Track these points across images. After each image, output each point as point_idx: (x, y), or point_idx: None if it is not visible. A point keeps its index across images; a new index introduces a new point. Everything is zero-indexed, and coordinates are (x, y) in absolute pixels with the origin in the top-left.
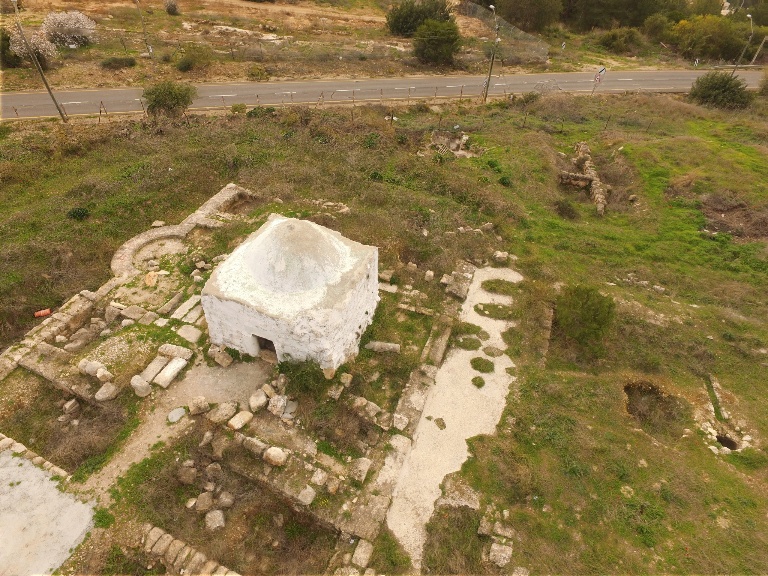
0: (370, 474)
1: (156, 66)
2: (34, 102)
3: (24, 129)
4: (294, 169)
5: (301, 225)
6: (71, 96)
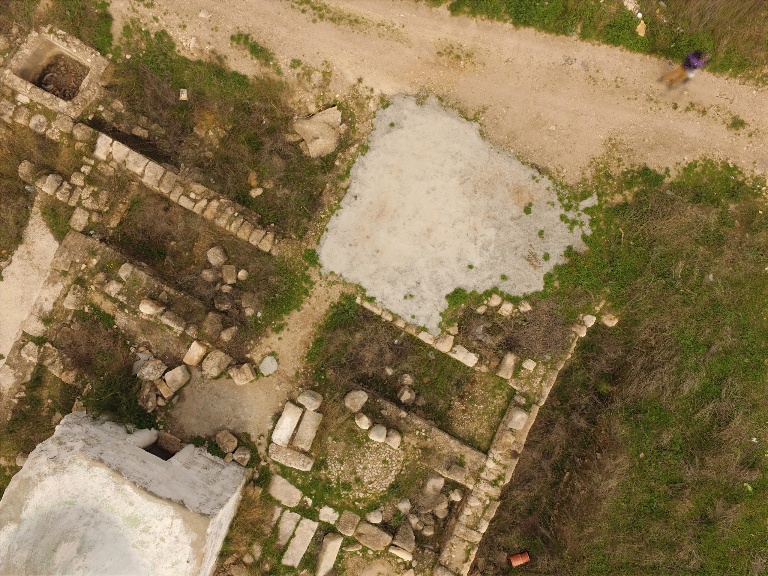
0: None
1: None
2: None
3: None
4: None
5: None
6: None
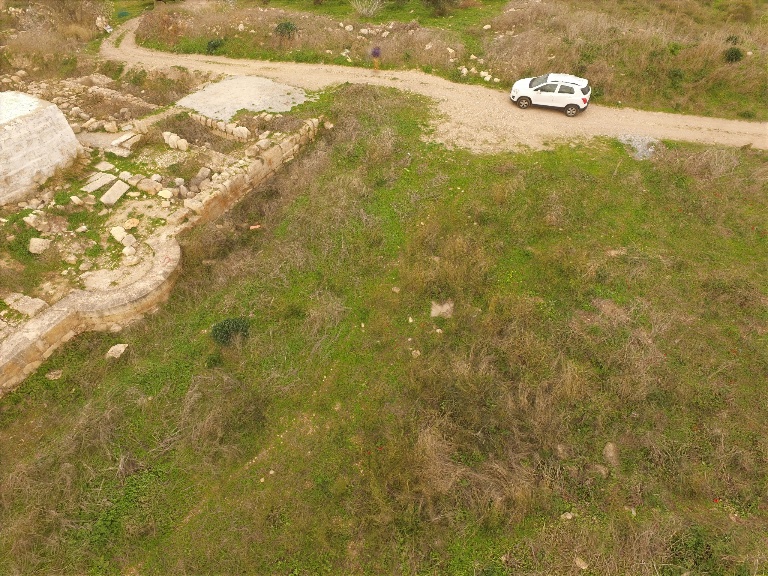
0: None
1: None
2: None
3: None
4: None
5: None
6: None
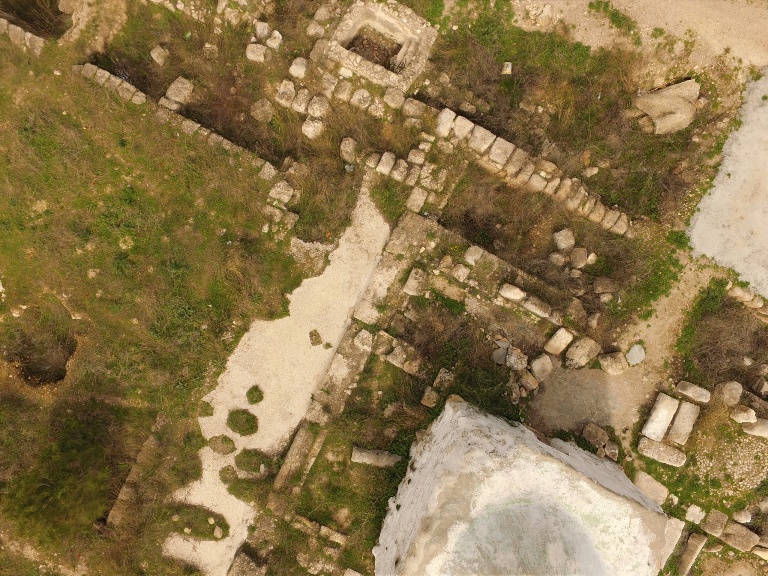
0: (405, 278)
1: None
2: None
3: None
4: None
5: None
6: None
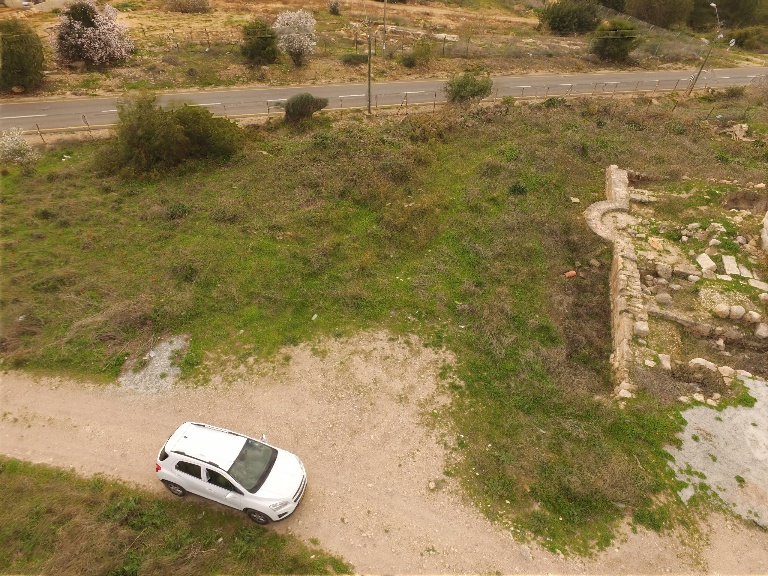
0: None
1: (386, 62)
2: (321, 95)
3: (341, 119)
4: (652, 152)
5: None
6: (344, 90)
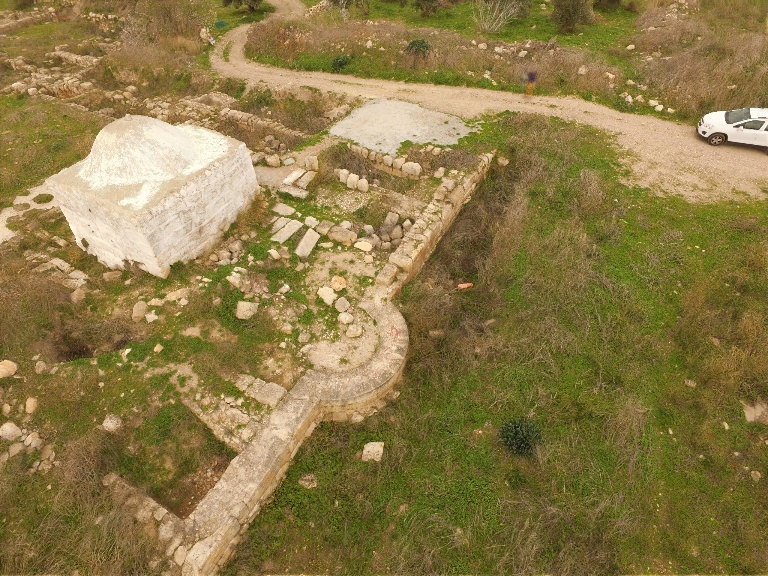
0: None
1: None
2: None
3: None
4: None
5: (116, 123)
6: None
